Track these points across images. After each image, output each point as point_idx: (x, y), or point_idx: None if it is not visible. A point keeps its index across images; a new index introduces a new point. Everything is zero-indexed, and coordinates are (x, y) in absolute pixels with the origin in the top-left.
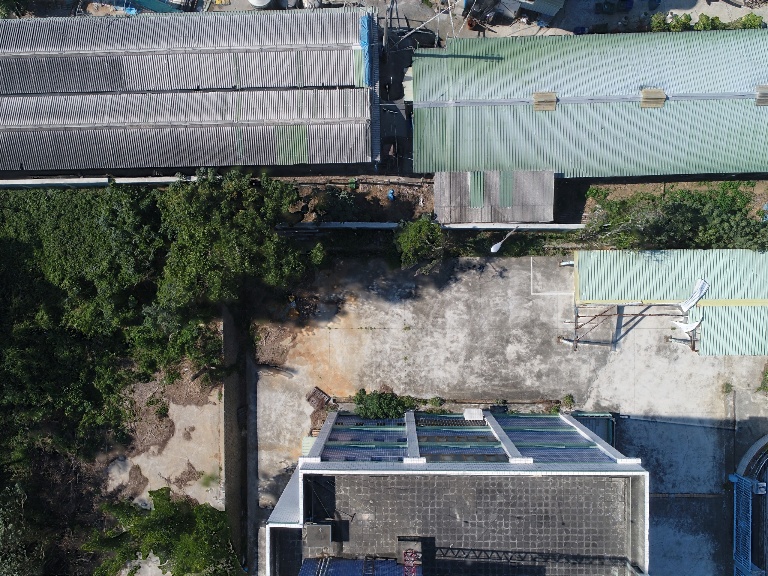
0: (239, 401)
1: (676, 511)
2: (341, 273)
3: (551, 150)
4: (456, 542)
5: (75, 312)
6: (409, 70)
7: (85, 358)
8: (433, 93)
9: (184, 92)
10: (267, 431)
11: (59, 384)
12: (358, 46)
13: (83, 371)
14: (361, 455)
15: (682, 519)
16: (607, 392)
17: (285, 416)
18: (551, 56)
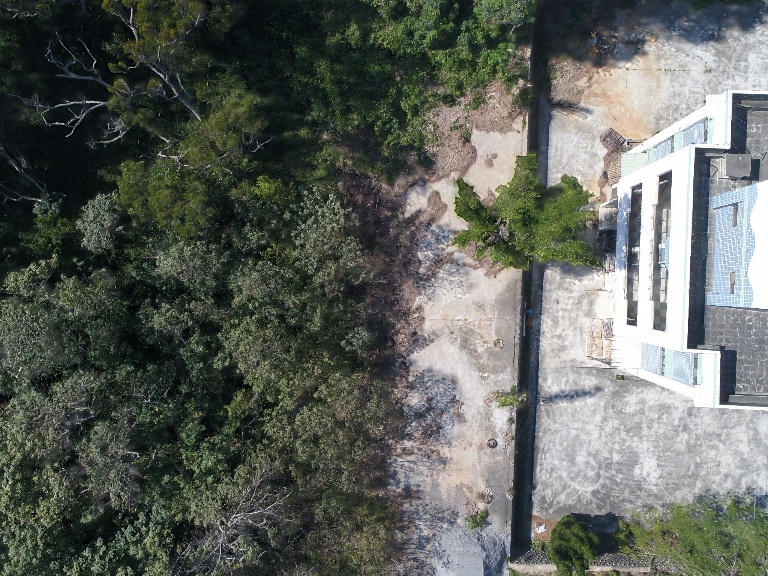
0: (529, 142)
1: None
2: (642, 13)
3: None
4: None
5: (383, 32)
6: None
7: (394, 76)
8: None
9: None
10: (558, 172)
11: None
12: None
13: (393, 88)
14: None
15: None
16: None
17: (577, 157)
18: None
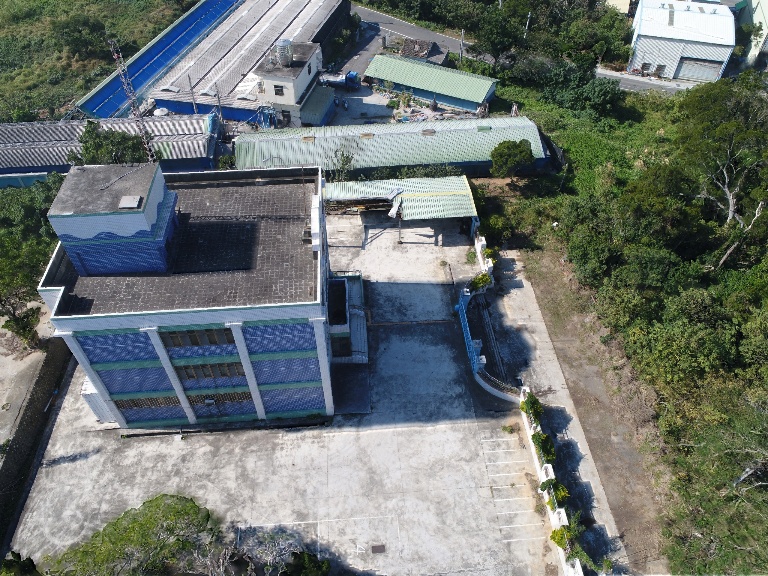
0: None
1: (419, 332)
2: None
3: (314, 159)
4: (204, 214)
5: None
6: None
7: None
8: None
9: None
10: None
11: None
12: (206, 118)
13: None
14: None
15: (424, 336)
16: (360, 269)
17: None
18: (315, 130)
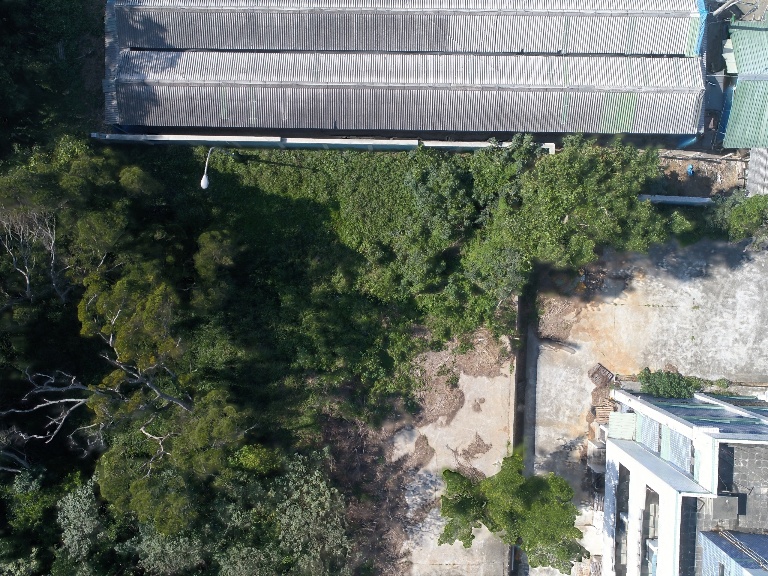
0: (517, 375)
1: None
2: None
3: None
4: None
5: (370, 277)
6: (728, 42)
7: (380, 324)
8: (757, 66)
9: (507, 55)
10: (546, 407)
11: (351, 349)
12: (696, 14)
13: (379, 337)
14: (733, 429)
15: None
16: None
17: (565, 392)
18: None
